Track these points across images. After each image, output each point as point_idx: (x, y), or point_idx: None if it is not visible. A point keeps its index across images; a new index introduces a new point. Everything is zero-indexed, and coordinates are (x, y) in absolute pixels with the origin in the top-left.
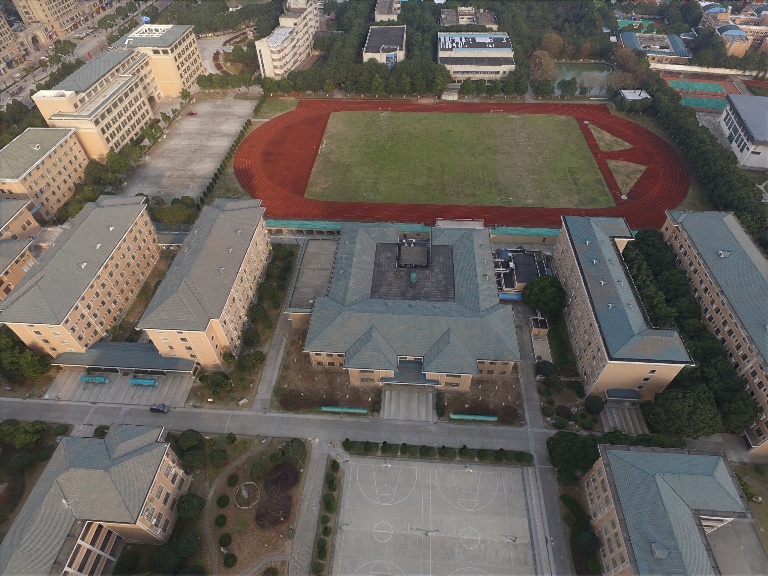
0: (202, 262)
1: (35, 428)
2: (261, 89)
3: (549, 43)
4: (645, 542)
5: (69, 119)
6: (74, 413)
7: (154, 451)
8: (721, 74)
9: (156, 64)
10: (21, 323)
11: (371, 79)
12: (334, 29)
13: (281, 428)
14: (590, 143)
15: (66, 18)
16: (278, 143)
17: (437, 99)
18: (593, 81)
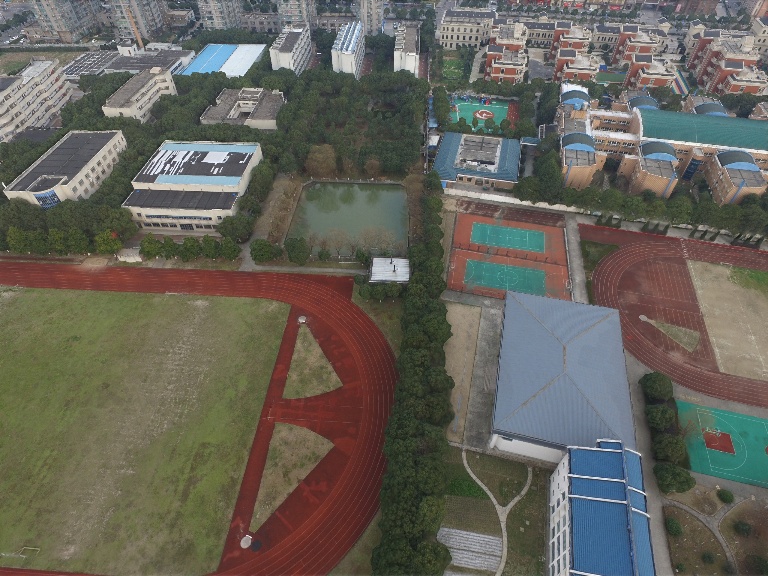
0: None
1: None
2: None
3: (314, 161)
4: None
5: None
6: None
7: None
8: (555, 211)
9: None
10: None
11: None
12: None
13: None
14: (276, 376)
15: None
16: None
17: (113, 260)
18: (338, 239)
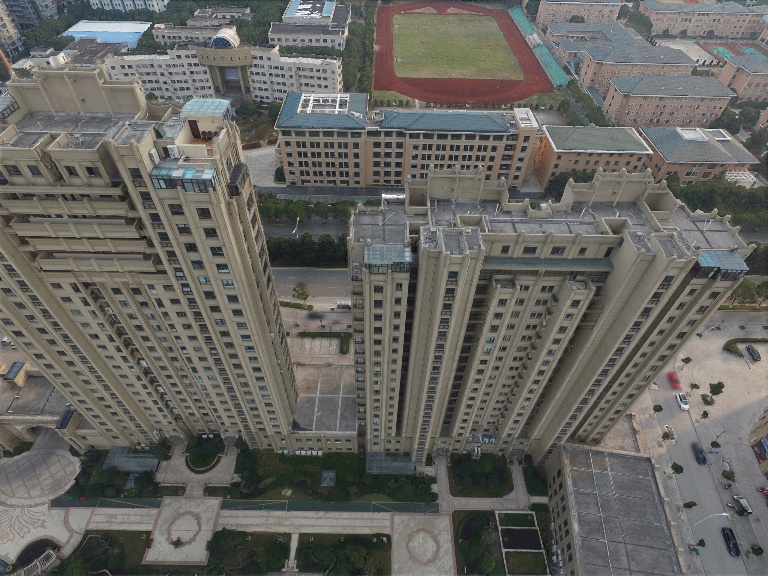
0: None
1: None
2: None
3: None
4: (678, 8)
5: None
6: None
7: None
8: None
9: None
10: None
11: None
12: None
13: None
14: None
15: None
16: (456, 93)
17: None
18: None
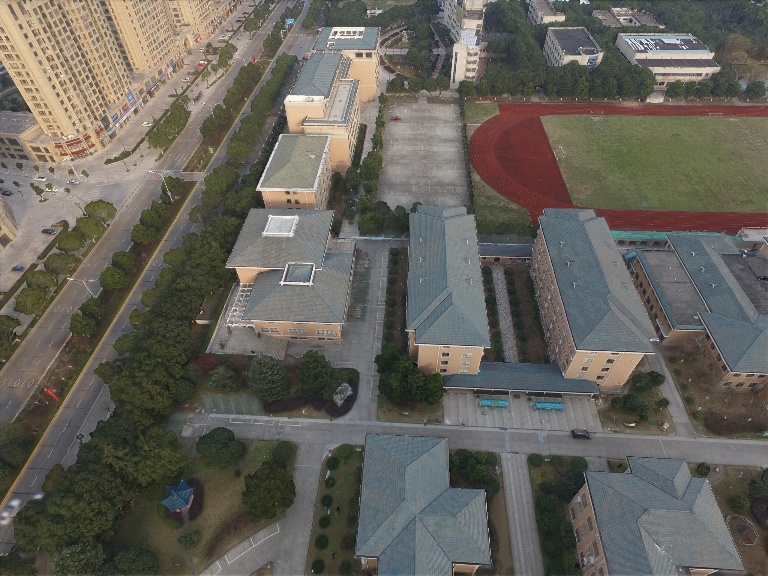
0: (609, 278)
1: (485, 458)
2: (450, 93)
3: (737, 44)
4: None
5: (322, 125)
6: (490, 440)
7: (705, 487)
8: None
9: (355, 67)
10: (446, 345)
11: (573, 82)
12: (482, 31)
13: (725, 455)
14: None
15: (208, 21)
16: (507, 148)
17: (641, 102)
18: None
